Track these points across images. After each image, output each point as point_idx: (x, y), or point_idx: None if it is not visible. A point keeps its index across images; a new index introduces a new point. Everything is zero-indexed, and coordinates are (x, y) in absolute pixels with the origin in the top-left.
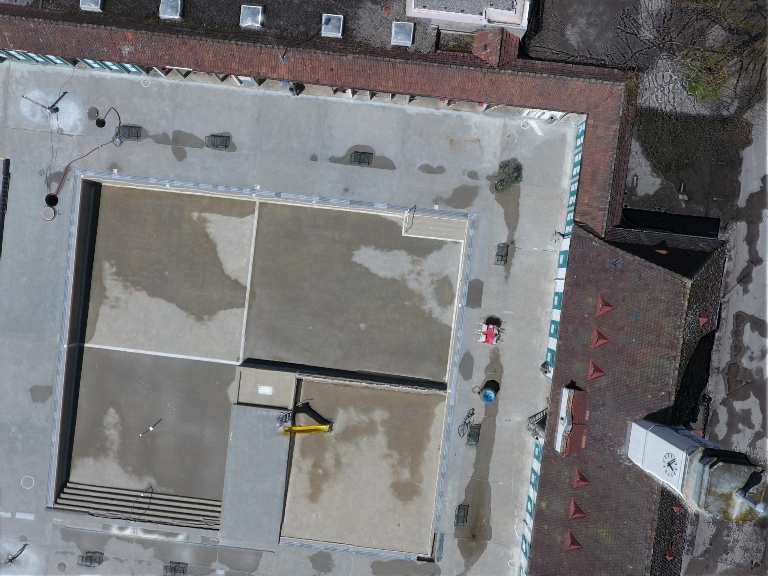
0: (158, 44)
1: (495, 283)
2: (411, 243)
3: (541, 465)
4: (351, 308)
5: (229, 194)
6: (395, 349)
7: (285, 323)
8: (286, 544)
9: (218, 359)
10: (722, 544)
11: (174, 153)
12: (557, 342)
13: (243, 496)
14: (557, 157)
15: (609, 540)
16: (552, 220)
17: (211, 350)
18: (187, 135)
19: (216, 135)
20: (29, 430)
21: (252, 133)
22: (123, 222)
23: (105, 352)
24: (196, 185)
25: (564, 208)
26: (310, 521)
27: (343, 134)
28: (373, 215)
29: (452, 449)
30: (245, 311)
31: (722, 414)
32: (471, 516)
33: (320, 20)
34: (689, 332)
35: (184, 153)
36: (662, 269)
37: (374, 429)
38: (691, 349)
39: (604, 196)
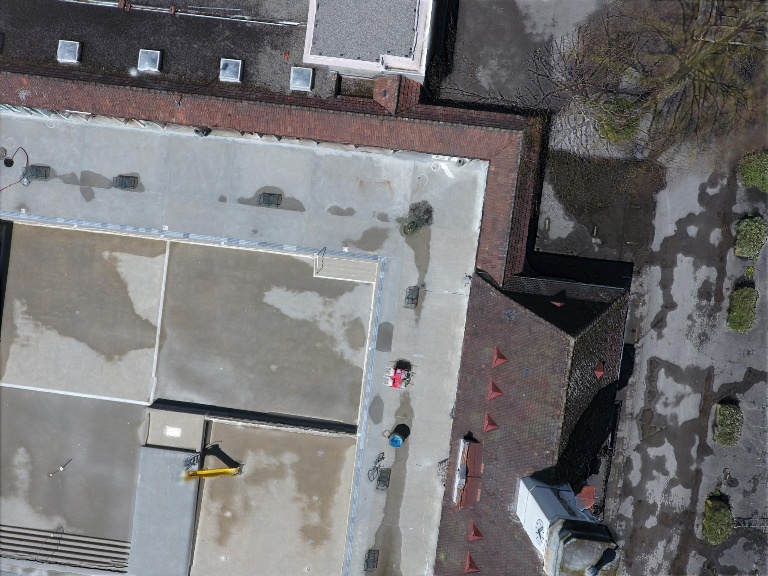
0: (55, 88)
1: (405, 326)
2: (322, 284)
3: (441, 516)
4: (262, 349)
5: (137, 235)
6: (306, 391)
7: (196, 364)
8: None
9: (129, 399)
10: None
11: (82, 193)
12: (457, 391)
13: (151, 538)
14: (468, 200)
15: None
16: (463, 263)
17: (122, 390)
18: (95, 175)
19: (124, 175)
20: None
21: (160, 174)
22: (34, 261)
23: (16, 391)
24: (104, 225)
25: (474, 251)
26: (219, 564)
27: (252, 175)
28: (284, 256)
29: (362, 493)
30: (155, 351)
31: (636, 461)
32: (381, 561)
33: (218, 65)
34: (578, 388)
35: (92, 193)
36: (549, 325)
37: (284, 472)
38: (583, 404)
39: (503, 245)
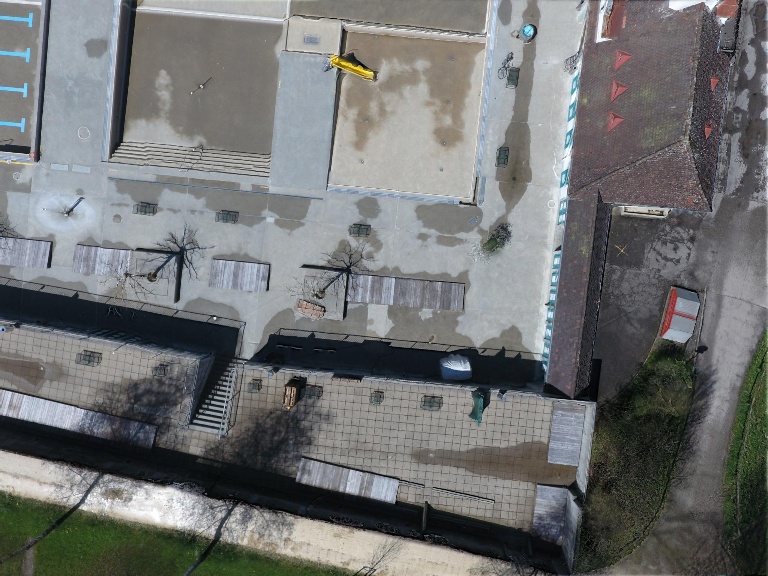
0: None
1: None
2: None
3: (582, 66)
4: None
5: None
6: (435, 3)
7: None
8: (333, 191)
9: (265, 17)
10: (753, 182)
11: None
12: None
13: (292, 142)
14: None
15: (652, 96)
16: None
17: (259, 9)
18: None
19: None
20: (85, 84)
21: None
22: None
23: (157, 13)
24: None
25: None
26: (356, 168)
27: None
28: None
29: (492, 93)
30: None
31: (751, 54)
32: (511, 159)
33: None
34: None
35: None
36: None
37: (417, 78)
38: None
39: None
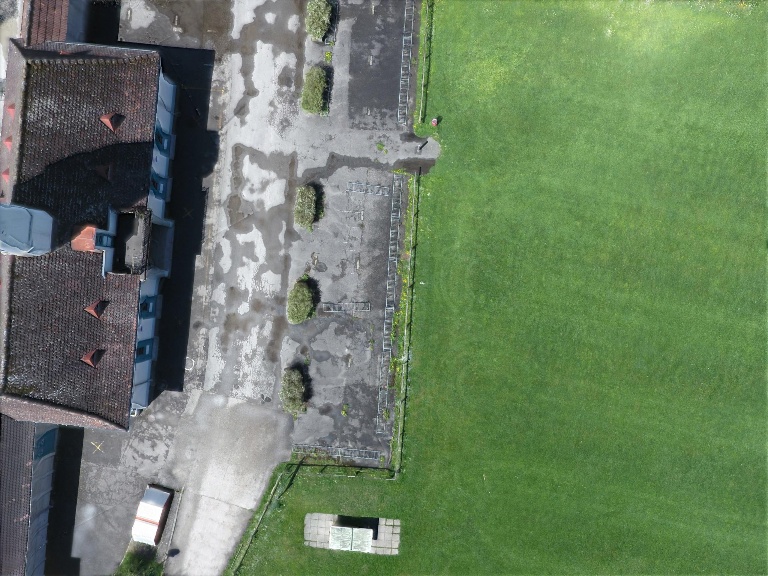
0: None
1: None
2: None
3: None
4: None
5: None
6: None
7: None
8: None
9: None
10: (232, 378)
11: None
12: None
13: None
14: None
15: None
16: None
17: None
18: None
19: None
20: None
21: None
22: None
23: None
24: None
25: None
26: None
27: None
28: None
29: None
30: None
31: (225, 247)
32: None
33: None
34: (58, 122)
35: None
36: None
37: None
38: (77, 145)
39: None
